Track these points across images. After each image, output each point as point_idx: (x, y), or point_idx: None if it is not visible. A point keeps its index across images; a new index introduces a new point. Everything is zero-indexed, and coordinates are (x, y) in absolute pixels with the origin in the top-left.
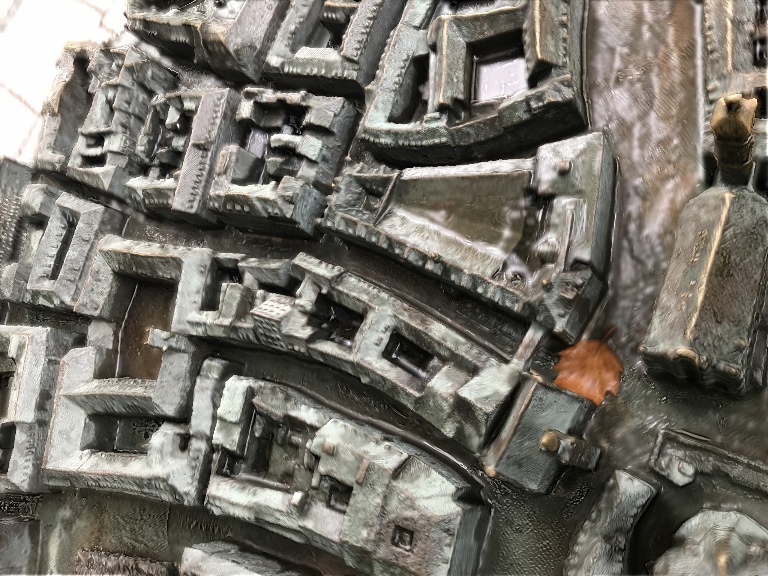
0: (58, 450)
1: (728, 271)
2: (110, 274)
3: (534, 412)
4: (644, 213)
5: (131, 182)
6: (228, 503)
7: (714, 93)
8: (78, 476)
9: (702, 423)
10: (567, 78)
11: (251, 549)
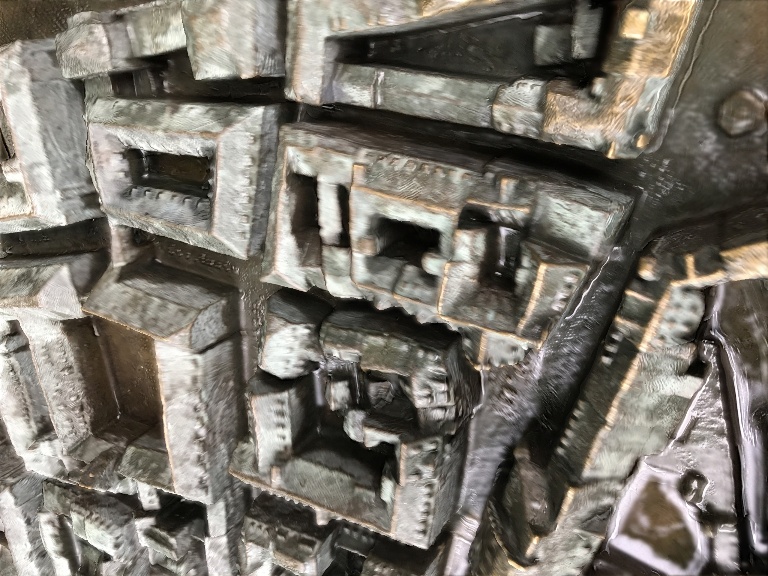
0: None
1: None
2: None
3: None
4: None
5: (278, 341)
6: (42, 535)
7: None
8: None
9: None
10: None
11: None
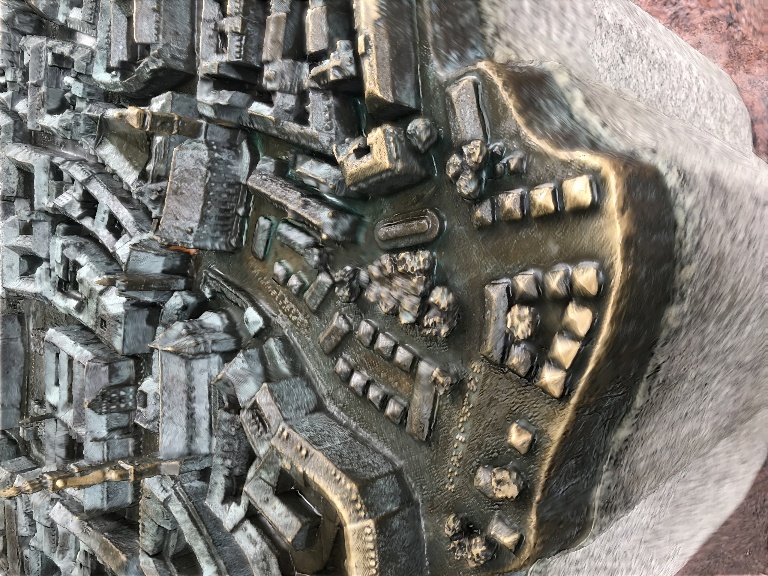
0: (8, 277)
1: (181, 191)
2: (16, 170)
3: (135, 263)
4: None
5: (18, 105)
6: (58, 306)
7: None
8: (15, 291)
9: (225, 265)
10: (156, 53)
11: (88, 329)
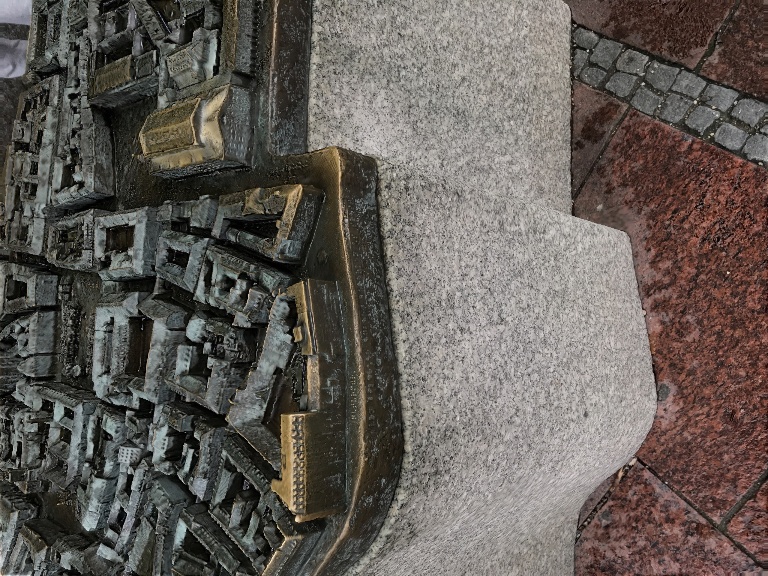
0: (103, 310)
1: None
2: None
3: None
4: None
5: (193, 324)
6: None
7: None
8: None
9: None
10: None
11: None
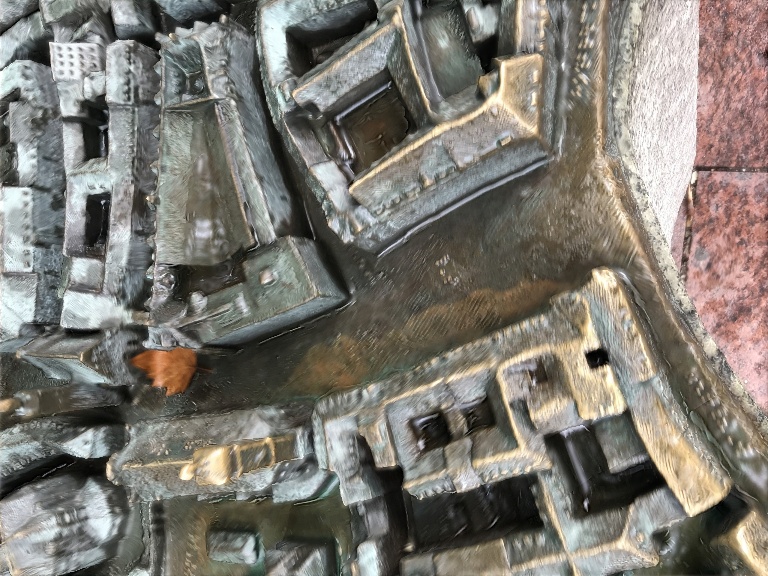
0: None
1: None
2: None
3: (72, 362)
4: (309, 352)
5: None
6: None
7: (367, 394)
8: None
9: None
10: (357, 228)
11: None
